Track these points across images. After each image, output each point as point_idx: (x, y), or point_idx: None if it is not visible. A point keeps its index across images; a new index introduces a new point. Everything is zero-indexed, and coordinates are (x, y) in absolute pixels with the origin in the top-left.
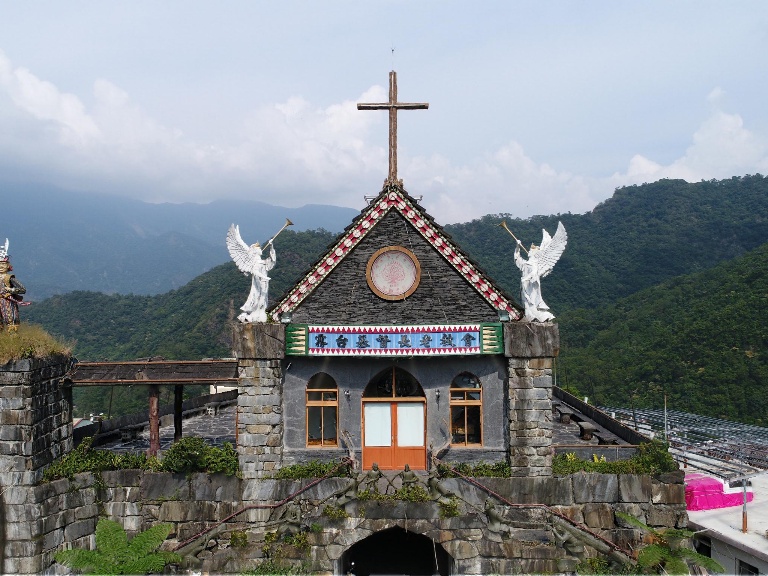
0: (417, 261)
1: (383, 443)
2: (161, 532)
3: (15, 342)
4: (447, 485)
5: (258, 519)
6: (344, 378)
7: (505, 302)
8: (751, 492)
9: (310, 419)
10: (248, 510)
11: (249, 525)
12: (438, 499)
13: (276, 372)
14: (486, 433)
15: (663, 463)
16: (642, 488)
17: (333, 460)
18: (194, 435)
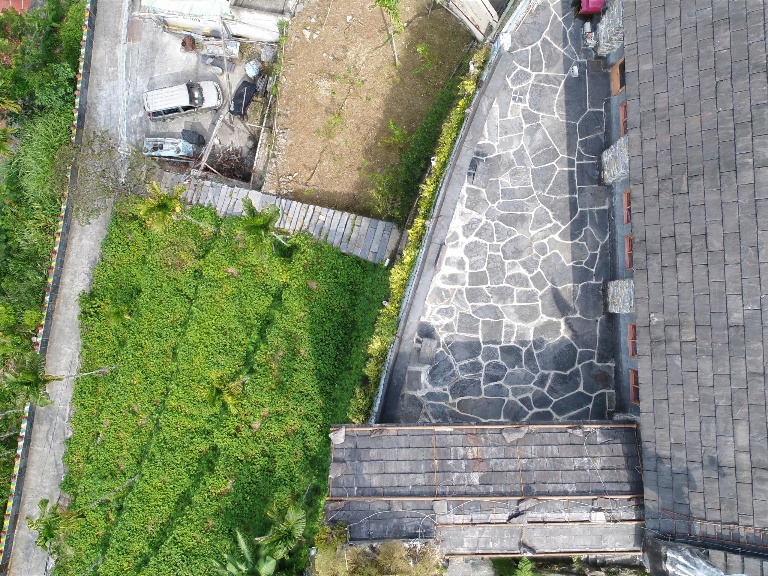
0: None
1: None
2: None
3: None
4: None
5: None
6: None
7: None
8: None
9: None
10: None
11: None
12: None
13: None
14: None
15: None
16: None
17: None
18: (499, 325)
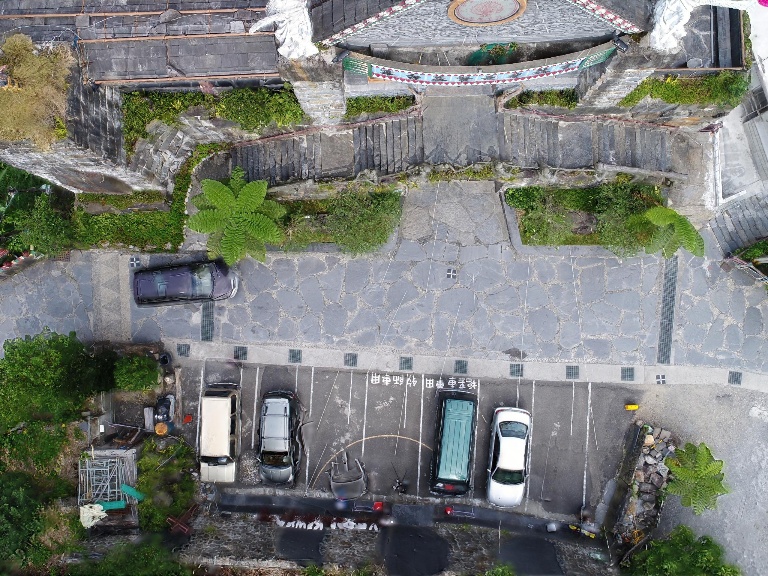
0: (523, 1)
1: None
2: (260, 191)
3: (29, 110)
4: None
5: (329, 128)
6: None
7: (631, 24)
8: None
9: None
10: None
11: None
12: None
13: None
14: None
15: None
16: None
17: (397, 93)
18: None
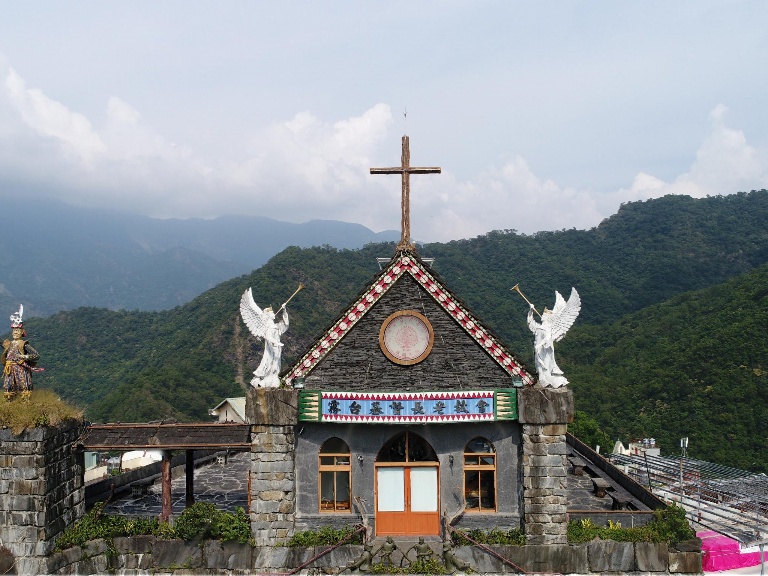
0: (430, 326)
1: (396, 508)
2: None
3: (29, 410)
4: (461, 553)
5: None
6: (357, 443)
7: (519, 367)
8: (767, 551)
9: (323, 484)
10: None
11: None
12: (453, 573)
13: (289, 438)
14: (500, 499)
15: (680, 532)
16: (659, 557)
17: (346, 526)
18: (205, 490)
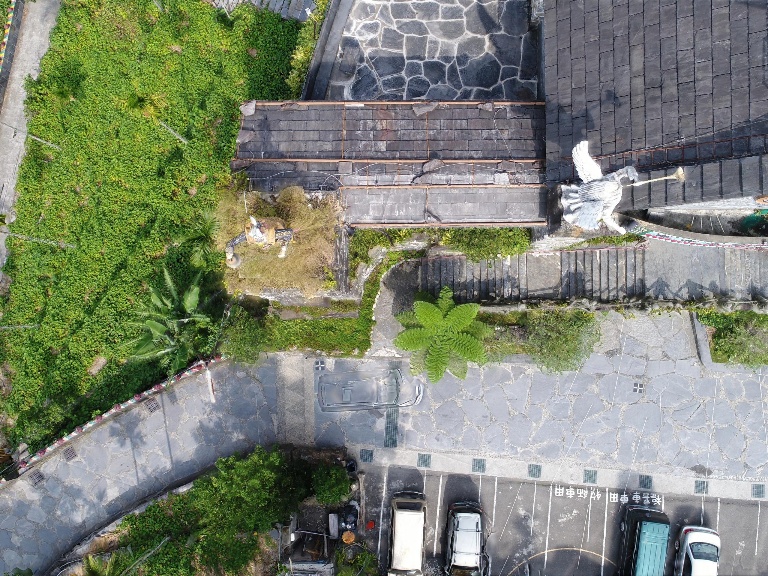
0: None
1: None
2: (471, 314)
3: (302, 263)
4: None
5: None
6: None
7: None
8: None
9: None
10: None
11: None
12: None
13: None
14: None
15: None
16: None
17: None
18: (424, 41)
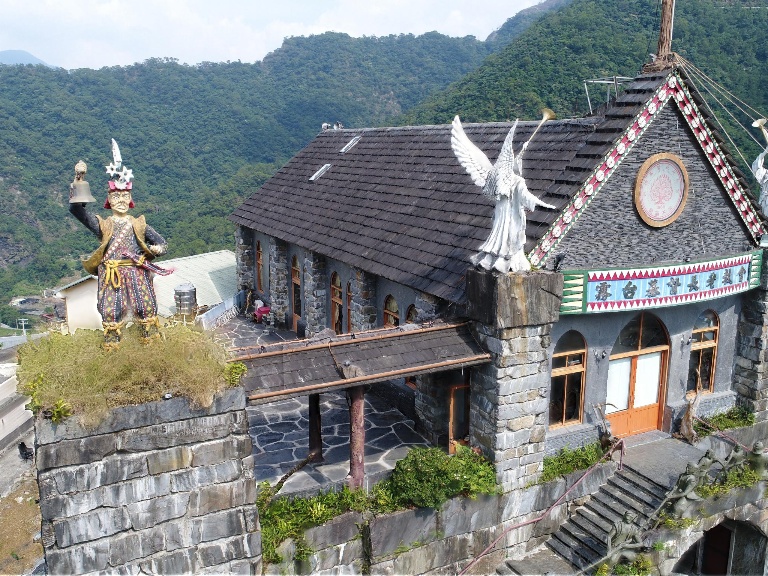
0: (686, 173)
1: (618, 407)
2: None
3: None
4: (702, 447)
5: (518, 541)
6: (595, 334)
7: (759, 223)
8: None
9: (551, 393)
10: (507, 533)
11: (505, 551)
12: (767, 477)
13: (546, 341)
14: (718, 377)
15: None
16: None
17: (583, 441)
18: (260, 416)
